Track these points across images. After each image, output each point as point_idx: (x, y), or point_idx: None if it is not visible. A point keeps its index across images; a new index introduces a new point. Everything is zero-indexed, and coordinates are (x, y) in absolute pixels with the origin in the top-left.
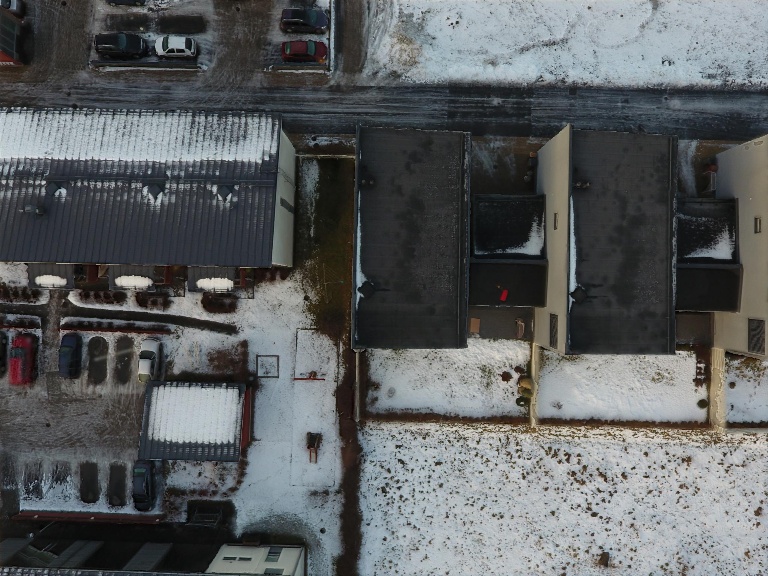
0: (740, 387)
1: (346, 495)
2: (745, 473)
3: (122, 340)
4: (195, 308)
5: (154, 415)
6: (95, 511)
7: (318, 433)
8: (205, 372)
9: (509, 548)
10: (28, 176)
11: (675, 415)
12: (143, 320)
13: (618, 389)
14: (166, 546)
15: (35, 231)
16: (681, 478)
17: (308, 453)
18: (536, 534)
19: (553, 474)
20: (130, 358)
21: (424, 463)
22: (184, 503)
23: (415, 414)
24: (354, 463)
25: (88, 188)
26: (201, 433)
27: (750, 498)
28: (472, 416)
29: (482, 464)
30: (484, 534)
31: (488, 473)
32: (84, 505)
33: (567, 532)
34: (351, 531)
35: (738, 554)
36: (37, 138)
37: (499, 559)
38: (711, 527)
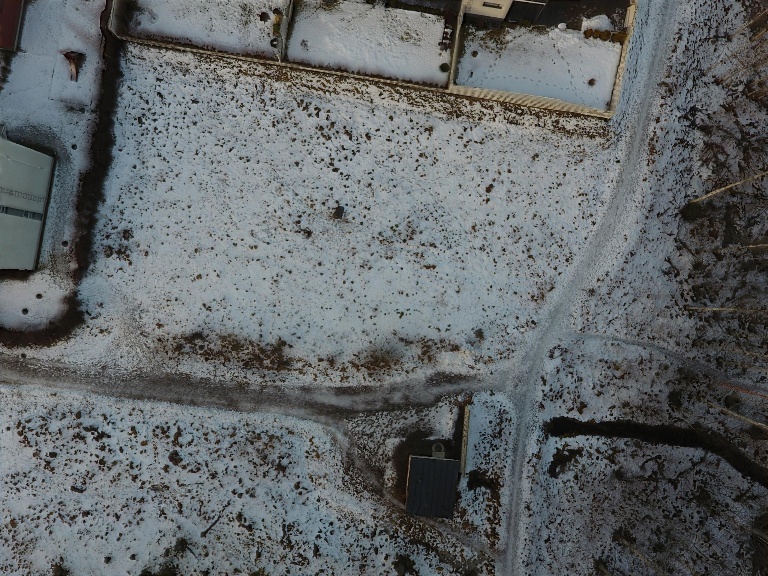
0: (482, 57)
1: (101, 116)
2: (482, 150)
3: None
4: None
5: None
6: None
7: (82, 53)
8: None
9: (251, 191)
10: None
11: (417, 75)
12: None
13: (367, 43)
14: None
15: None
16: (422, 147)
17: (70, 71)
18: (278, 181)
19: (302, 126)
20: None
21: (182, 100)
22: None
23: (174, 43)
24: (113, 87)
25: None
26: None
27: (484, 174)
28: (227, 51)
29: (237, 108)
30: (229, 175)
31: (241, 118)
32: None
33: (308, 183)
34: (101, 150)
35: (466, 227)
36: None
37: (240, 200)
38: (444, 198)
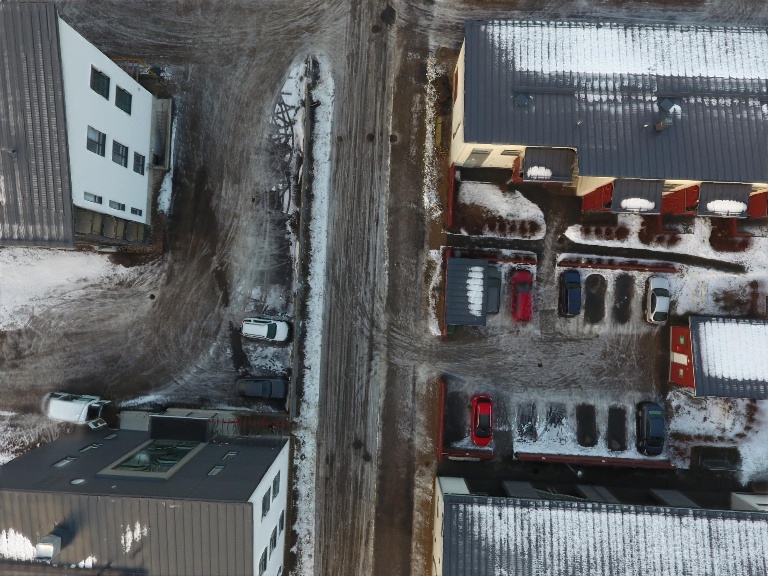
0: None
1: None
2: None
3: (622, 278)
4: (702, 246)
5: (706, 351)
6: (594, 455)
7: None
8: (710, 313)
9: None
10: (637, 92)
11: None
12: (645, 258)
13: None
14: (677, 492)
15: (657, 148)
16: None
17: None
18: None
19: None
20: (630, 297)
21: None
22: (688, 449)
23: None
24: None
25: (703, 105)
26: (760, 371)
27: None
28: None
29: None
30: None
31: None
32: (582, 449)
33: None
34: None
35: None
36: (636, 54)
37: None
38: None
